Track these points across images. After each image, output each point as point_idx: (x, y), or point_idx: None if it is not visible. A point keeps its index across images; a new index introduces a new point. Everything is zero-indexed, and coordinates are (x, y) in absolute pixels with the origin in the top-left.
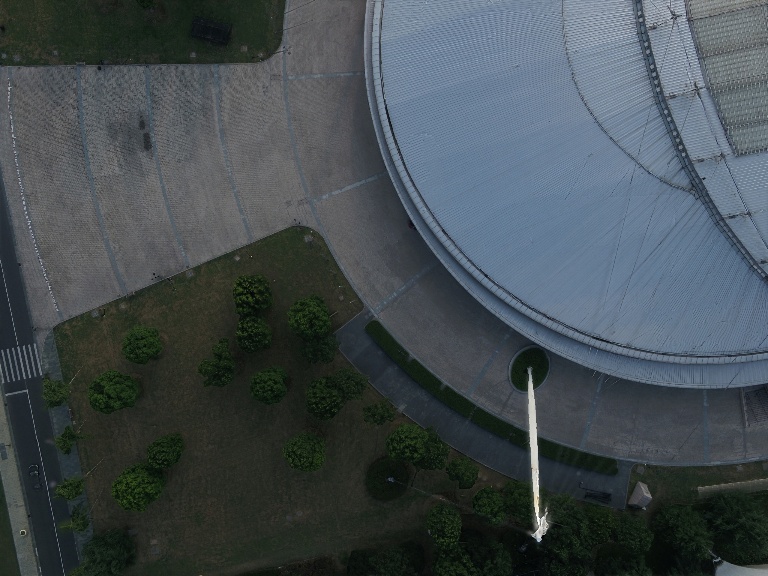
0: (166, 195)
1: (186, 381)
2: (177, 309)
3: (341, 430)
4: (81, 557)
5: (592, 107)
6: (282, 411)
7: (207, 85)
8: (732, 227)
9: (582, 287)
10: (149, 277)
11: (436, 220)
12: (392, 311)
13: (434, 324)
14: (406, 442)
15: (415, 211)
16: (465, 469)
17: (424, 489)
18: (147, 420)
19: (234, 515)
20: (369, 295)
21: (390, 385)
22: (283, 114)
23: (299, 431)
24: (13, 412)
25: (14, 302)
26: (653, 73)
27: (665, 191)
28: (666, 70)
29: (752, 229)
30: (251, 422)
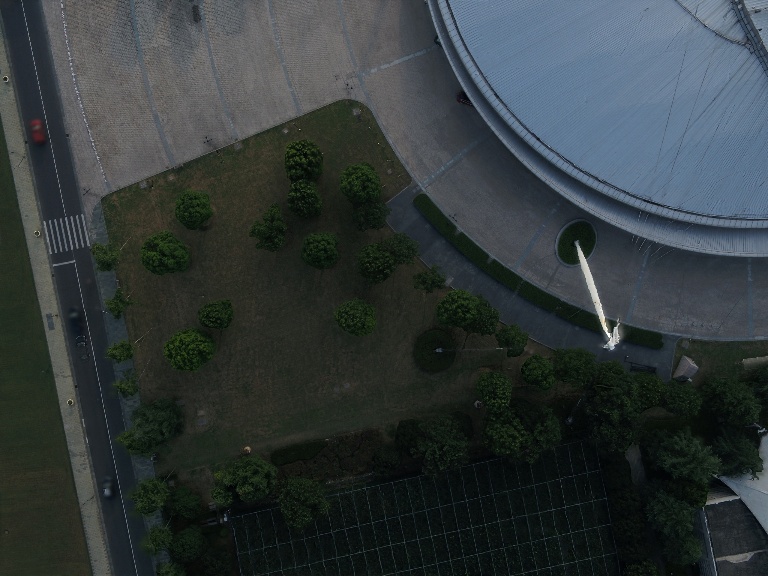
0: (215, 67)
1: (234, 252)
2: (225, 181)
3: (389, 302)
4: (128, 428)
5: None
6: (330, 283)
7: None
8: None
9: (635, 147)
10: (197, 149)
11: (488, 84)
12: (440, 185)
13: (481, 198)
14: (459, 302)
15: (466, 78)
16: (515, 334)
17: (471, 362)
18: (195, 291)
19: (281, 386)
20: (417, 169)
21: (437, 258)
22: None
23: None
24: (60, 283)
25: (62, 173)
26: None
27: (720, 45)
28: None
29: None
30: (299, 293)
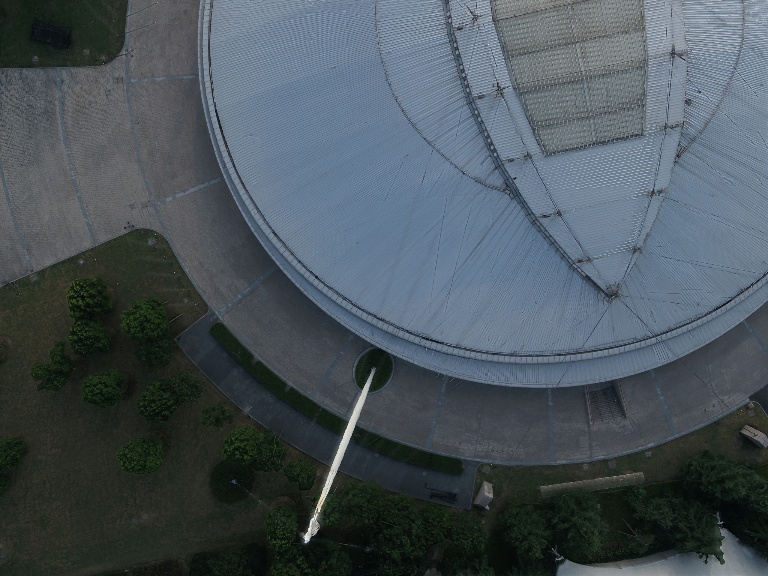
0: (9, 199)
1: (29, 385)
2: (21, 313)
3: (186, 432)
4: None
5: (406, 108)
6: (126, 414)
7: (50, 89)
8: (546, 226)
9: (407, 288)
10: None
11: (267, 222)
12: (237, 313)
13: (279, 326)
14: (235, 444)
15: (250, 213)
16: (301, 470)
17: (269, 491)
18: None
19: (79, 519)
20: (214, 297)
21: (235, 387)
22: (126, 117)
23: (143, 434)
24: None
25: None
26: (463, 73)
27: (480, 191)
28: (473, 70)
29: (565, 228)
30: (95, 425)
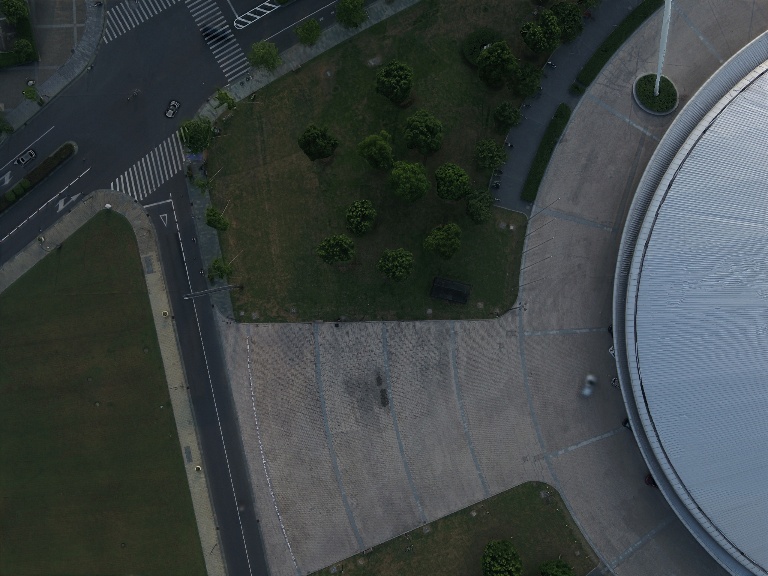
0: (403, 451)
1: None
2: (415, 565)
3: None
4: None
5: None
6: None
7: (443, 341)
8: None
9: None
10: (386, 533)
11: (691, 497)
12: (628, 566)
13: None
14: None
15: (664, 481)
16: None
17: None
18: None
19: None
20: (605, 550)
21: None
22: (519, 370)
23: None
24: None
25: (253, 558)
26: None
27: None
28: None
29: None
30: None
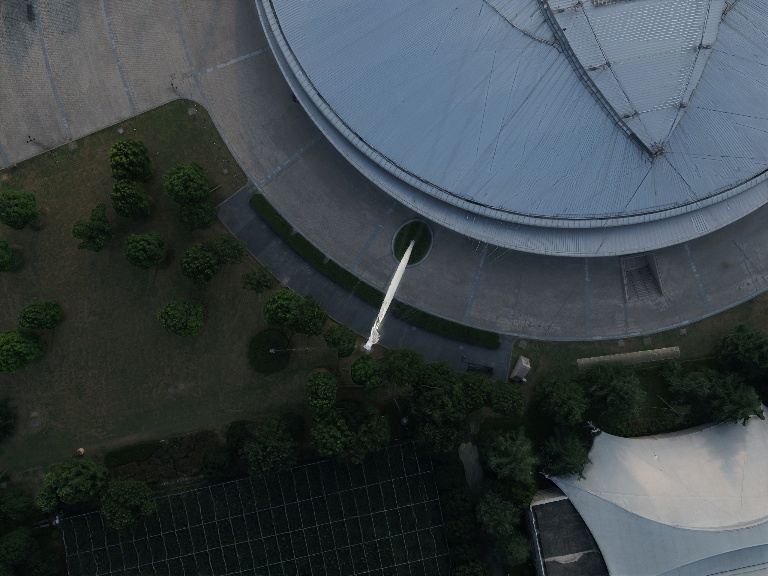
0: (49, 67)
1: (67, 252)
2: (59, 181)
3: (224, 303)
4: None
5: None
6: (164, 283)
7: None
8: (594, 80)
9: (453, 147)
10: (31, 149)
11: (312, 84)
12: (276, 185)
13: (318, 198)
14: (278, 302)
15: (294, 78)
16: (341, 334)
17: (307, 362)
18: (27, 291)
19: (115, 387)
20: (253, 169)
21: (274, 259)
22: None
23: None
24: None
25: None
26: None
27: (529, 45)
28: None
29: (613, 81)
30: (133, 294)
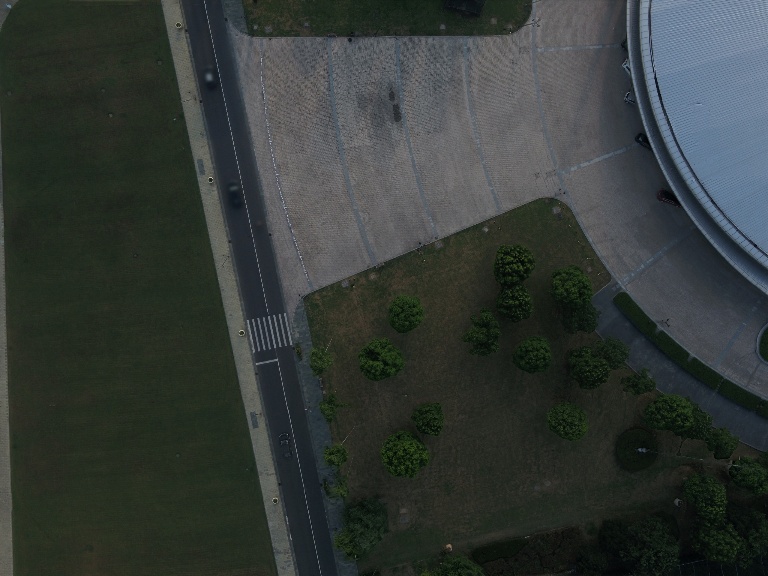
0: (415, 166)
1: (437, 351)
2: (427, 280)
3: (590, 401)
4: (331, 525)
5: None
6: (531, 382)
7: (456, 57)
8: None
9: None
10: (398, 248)
11: (705, 190)
12: (639, 283)
13: (681, 296)
14: (679, 410)
15: (677, 182)
16: (727, 439)
17: (672, 460)
18: (398, 390)
19: (483, 485)
20: (617, 267)
21: (637, 357)
22: (532, 86)
23: (548, 401)
24: (264, 381)
25: (265, 272)
26: None
27: None
28: None
29: None
30: (501, 392)
